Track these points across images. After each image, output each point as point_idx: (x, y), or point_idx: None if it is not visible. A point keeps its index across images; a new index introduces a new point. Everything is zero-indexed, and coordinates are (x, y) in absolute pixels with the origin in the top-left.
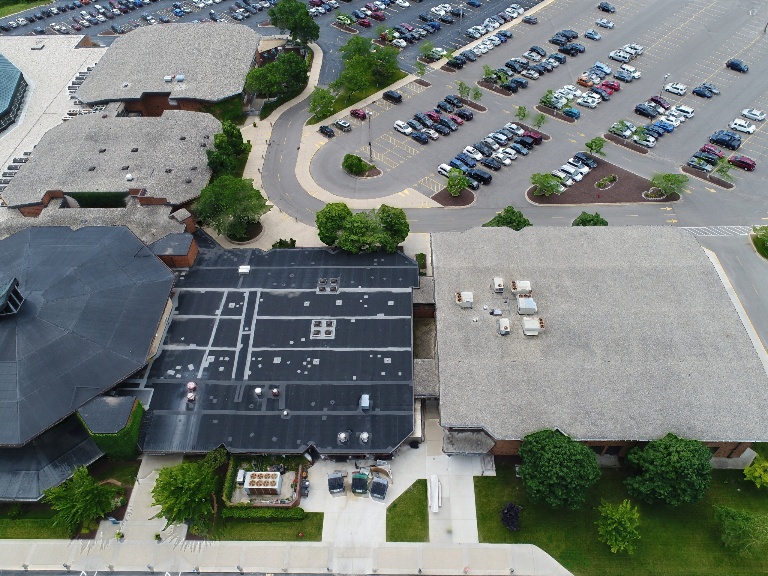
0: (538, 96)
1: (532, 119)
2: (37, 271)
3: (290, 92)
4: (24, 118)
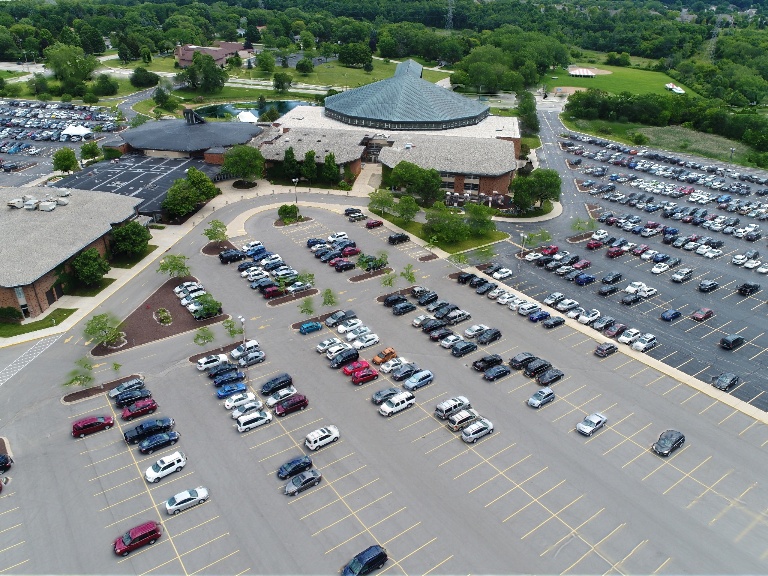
0: (368, 318)
1: (317, 303)
2: (217, 127)
3: (424, 202)
4: (397, 132)
